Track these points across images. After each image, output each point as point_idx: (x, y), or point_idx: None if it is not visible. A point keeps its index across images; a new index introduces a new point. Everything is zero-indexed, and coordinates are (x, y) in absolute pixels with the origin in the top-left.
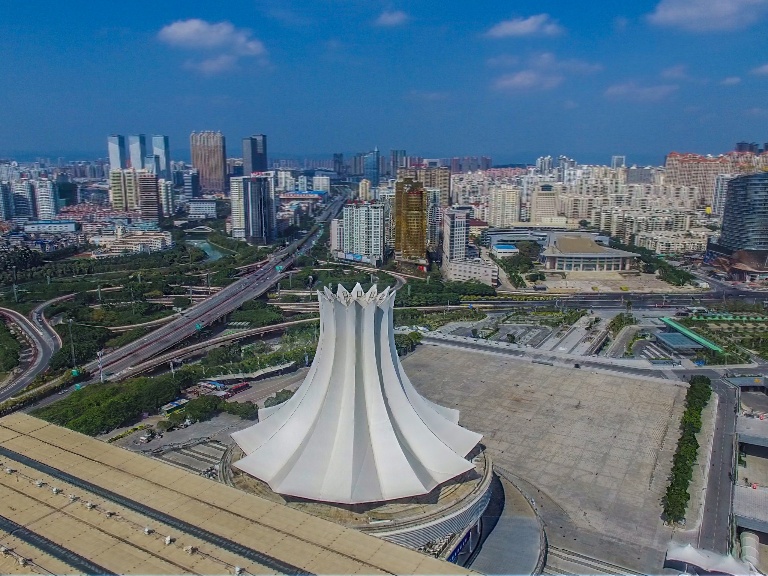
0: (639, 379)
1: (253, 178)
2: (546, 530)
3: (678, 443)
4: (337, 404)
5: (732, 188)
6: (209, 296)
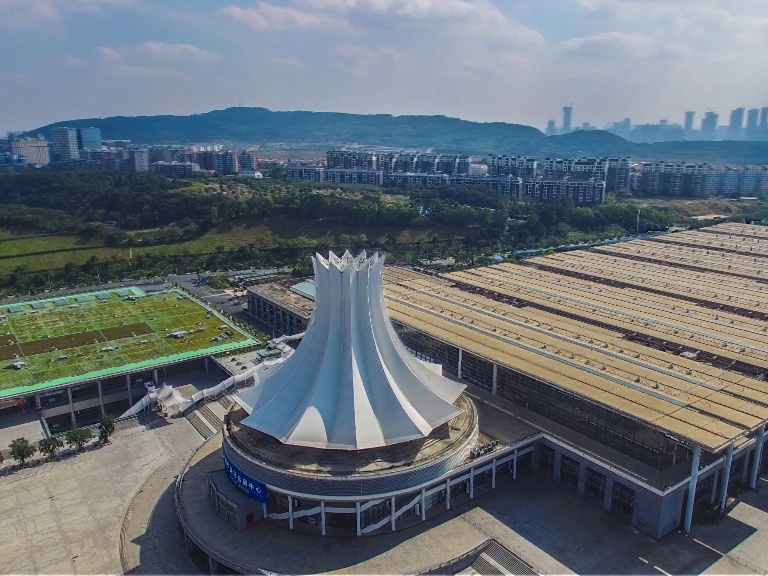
0: None
1: None
2: None
3: None
4: None
5: None
6: None
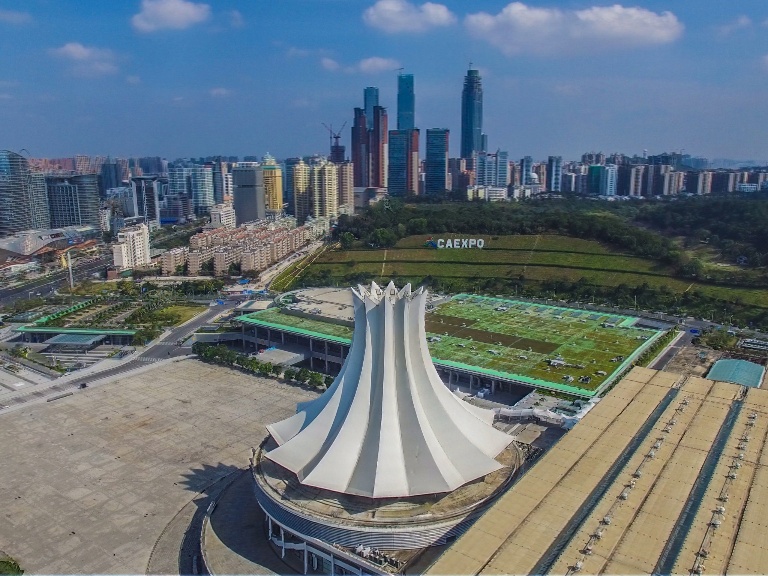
0: (147, 370)
1: None
2: None
3: (282, 383)
4: None
5: None
6: None
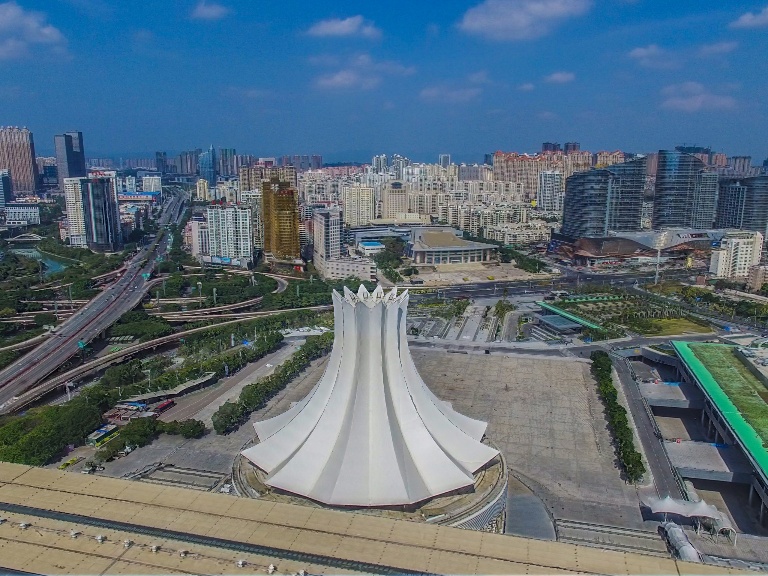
0: (545, 359)
1: (94, 179)
2: None
3: (604, 412)
4: (365, 407)
5: (571, 183)
6: (77, 310)
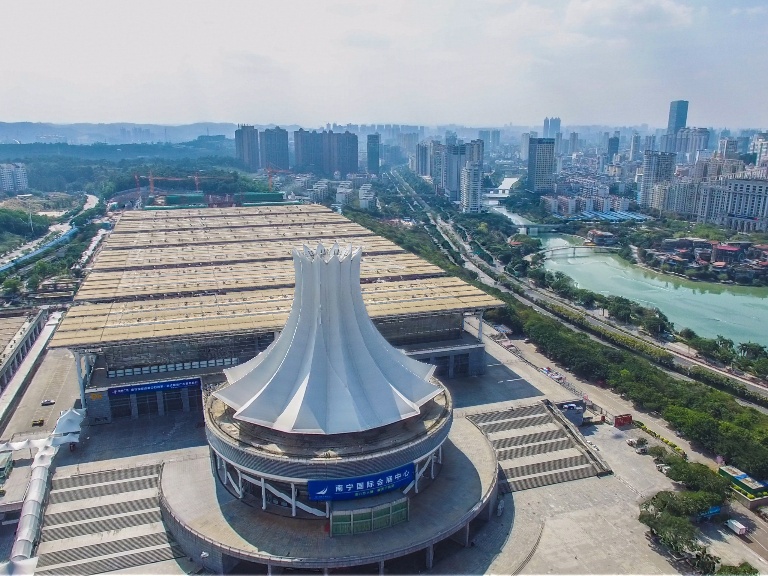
0: None
1: None
2: (185, 573)
3: None
4: None
5: None
6: None
